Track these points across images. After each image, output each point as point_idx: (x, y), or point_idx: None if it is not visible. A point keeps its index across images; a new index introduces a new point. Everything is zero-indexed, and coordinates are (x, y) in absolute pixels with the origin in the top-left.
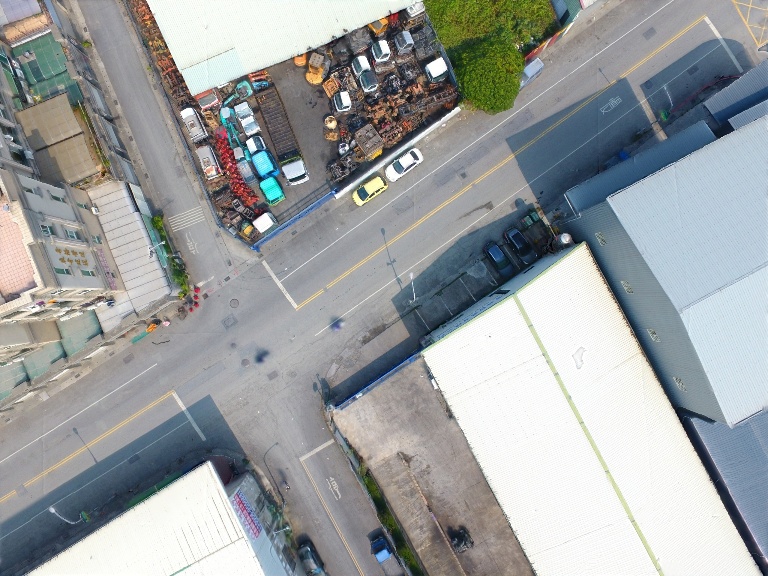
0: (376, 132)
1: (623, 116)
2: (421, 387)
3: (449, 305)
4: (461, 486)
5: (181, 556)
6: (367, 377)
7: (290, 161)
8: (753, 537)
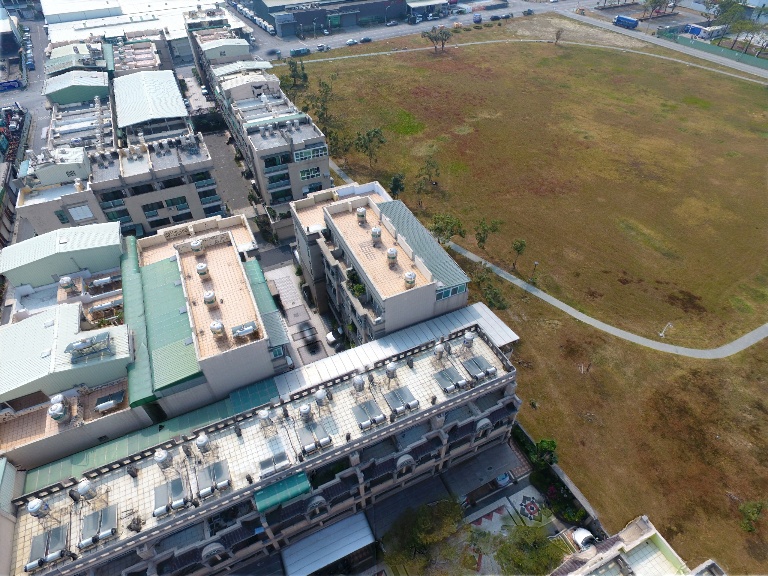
0: None
1: None
2: None
3: None
4: None
5: None
6: (3, 91)
7: None
8: None
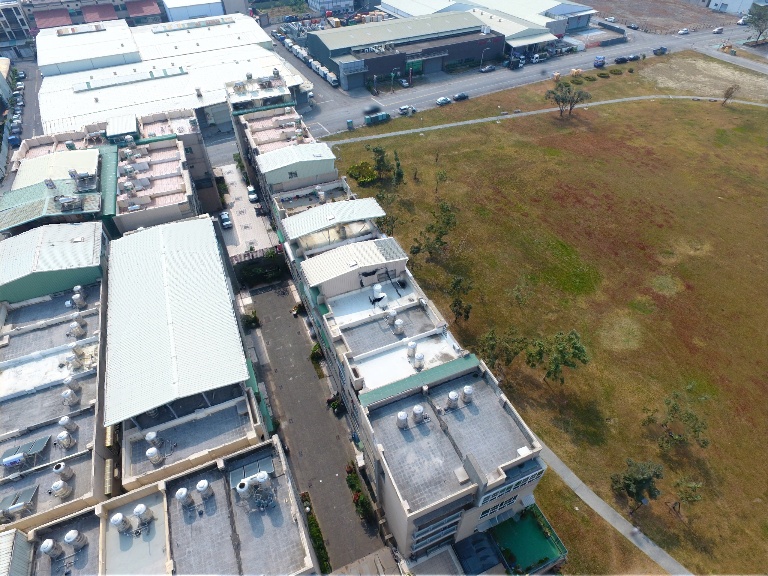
0: None
1: None
2: None
3: None
4: None
5: (76, 119)
6: None
7: None
8: None
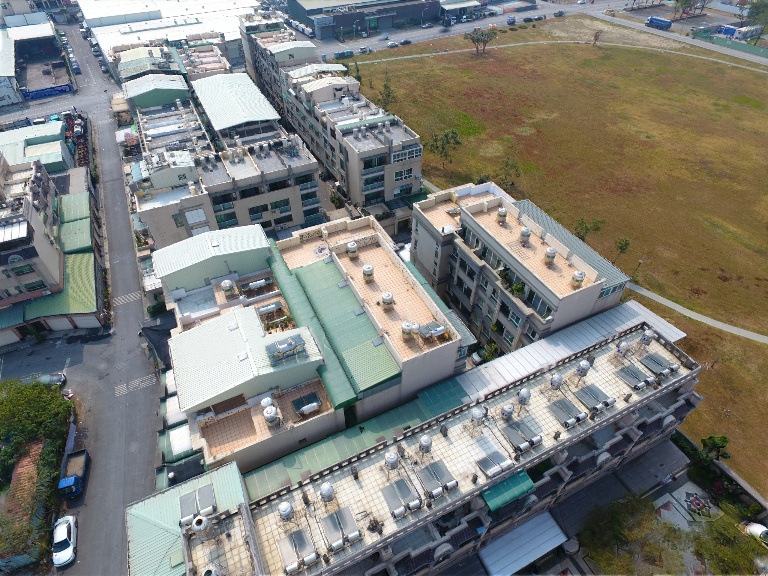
0: None
1: None
2: None
3: (6, 108)
4: (38, 80)
5: None
6: (55, 95)
7: (39, 122)
8: None
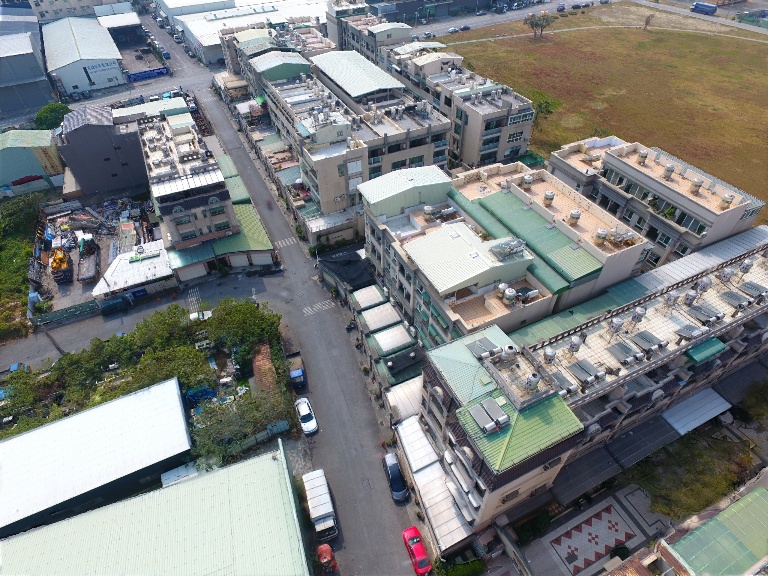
0: (114, 106)
1: (3, 122)
2: (135, 76)
3: None
4: None
5: None
6: None
7: (155, 99)
8: (40, 39)
